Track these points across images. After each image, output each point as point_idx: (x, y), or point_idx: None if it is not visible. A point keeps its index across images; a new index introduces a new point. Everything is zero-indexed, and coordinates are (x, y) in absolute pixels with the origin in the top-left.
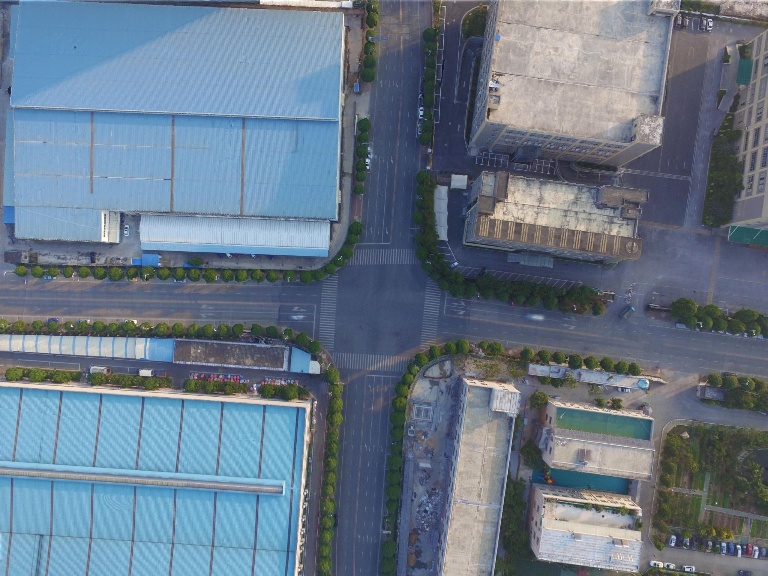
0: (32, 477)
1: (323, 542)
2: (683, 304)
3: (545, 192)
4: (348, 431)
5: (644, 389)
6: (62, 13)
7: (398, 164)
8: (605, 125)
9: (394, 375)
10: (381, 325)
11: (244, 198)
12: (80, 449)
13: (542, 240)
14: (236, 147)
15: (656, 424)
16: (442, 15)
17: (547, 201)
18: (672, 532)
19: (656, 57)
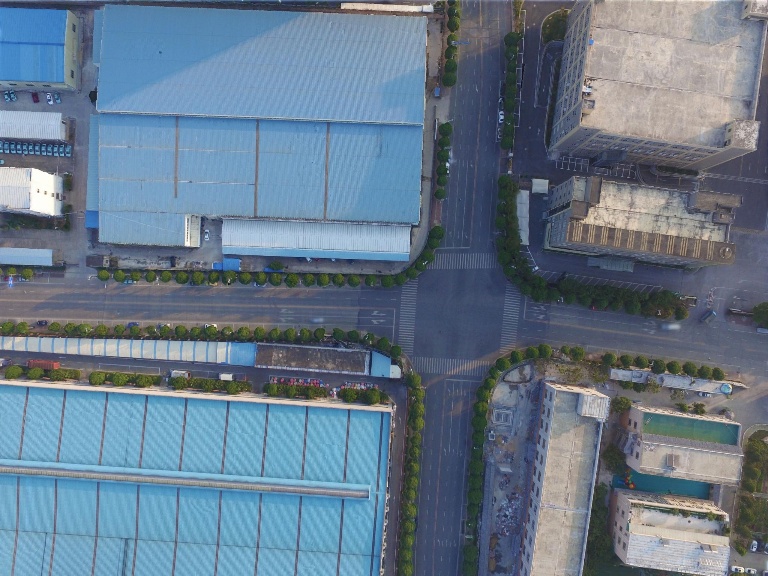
0: (119, 481)
1: (406, 546)
2: None
3: (636, 197)
4: (427, 435)
5: (726, 394)
6: (147, 18)
7: (478, 168)
8: (698, 130)
9: (473, 379)
10: (461, 329)
11: (328, 203)
12: (166, 453)
13: (635, 245)
14: (320, 152)
15: None
16: (522, 19)
17: (638, 206)
18: (753, 537)
19: (749, 61)
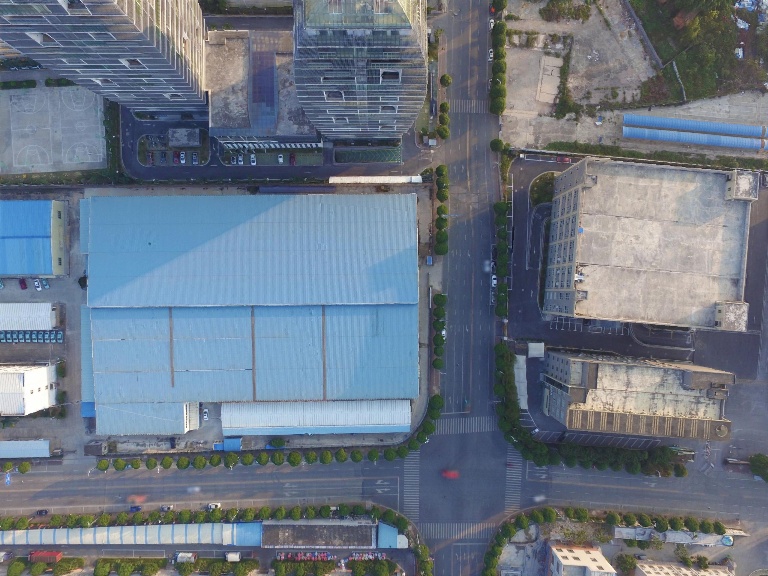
0: None
1: None
2: (764, 464)
3: (632, 376)
4: None
5: (728, 545)
6: (134, 209)
7: (473, 332)
8: (689, 310)
9: (480, 542)
10: (465, 493)
11: (326, 383)
12: None
13: (634, 429)
14: (317, 334)
15: (740, 575)
16: (510, 183)
17: (634, 385)
18: None
19: (735, 240)
